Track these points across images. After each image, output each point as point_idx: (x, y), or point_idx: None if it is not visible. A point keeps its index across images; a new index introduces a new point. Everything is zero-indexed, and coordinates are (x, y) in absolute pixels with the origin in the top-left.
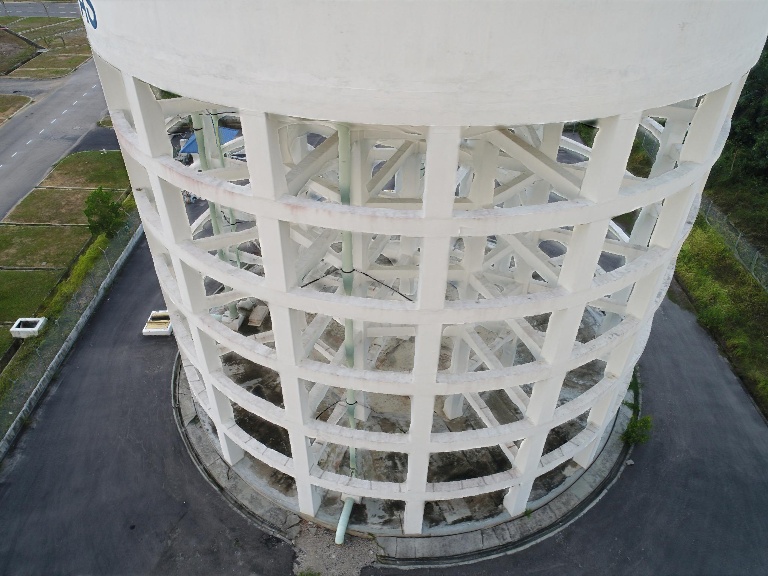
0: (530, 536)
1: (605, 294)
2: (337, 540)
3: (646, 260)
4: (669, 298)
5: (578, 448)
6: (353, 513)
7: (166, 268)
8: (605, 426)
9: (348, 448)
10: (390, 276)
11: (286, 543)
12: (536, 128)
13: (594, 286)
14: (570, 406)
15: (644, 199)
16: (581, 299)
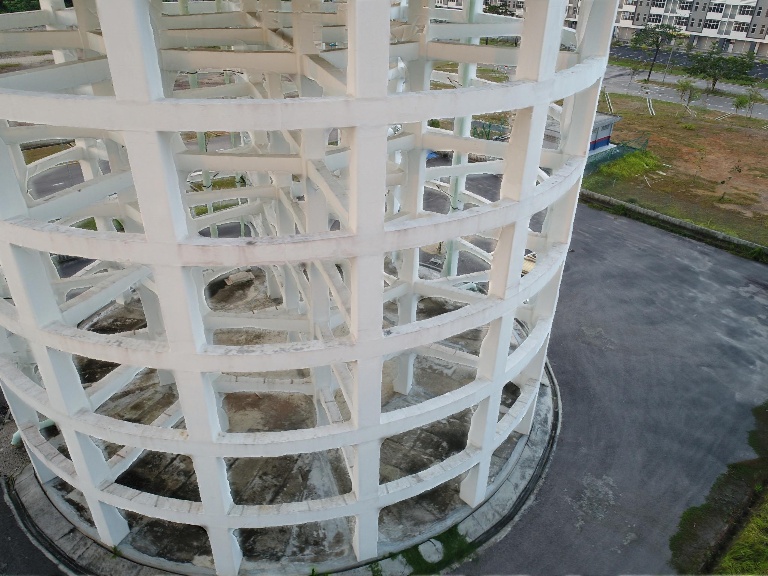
0: (95, 575)
1: (31, 245)
2: (12, 439)
3: (103, 235)
4: (672, 537)
5: (156, 509)
6: (44, 431)
7: (62, 153)
8: (223, 524)
9: (121, 392)
10: (138, 218)
11: (4, 417)
12: (428, 147)
13: (9, 222)
14: (104, 421)
15: (0, 106)
16: (0, 232)
